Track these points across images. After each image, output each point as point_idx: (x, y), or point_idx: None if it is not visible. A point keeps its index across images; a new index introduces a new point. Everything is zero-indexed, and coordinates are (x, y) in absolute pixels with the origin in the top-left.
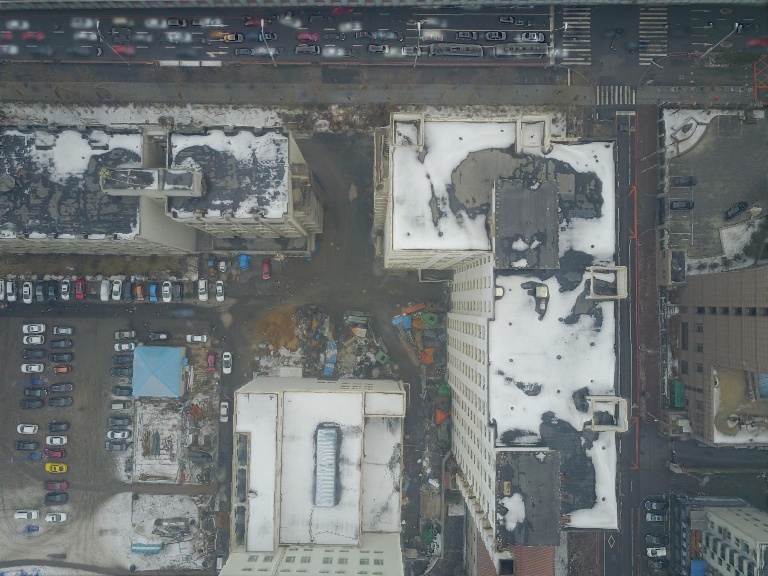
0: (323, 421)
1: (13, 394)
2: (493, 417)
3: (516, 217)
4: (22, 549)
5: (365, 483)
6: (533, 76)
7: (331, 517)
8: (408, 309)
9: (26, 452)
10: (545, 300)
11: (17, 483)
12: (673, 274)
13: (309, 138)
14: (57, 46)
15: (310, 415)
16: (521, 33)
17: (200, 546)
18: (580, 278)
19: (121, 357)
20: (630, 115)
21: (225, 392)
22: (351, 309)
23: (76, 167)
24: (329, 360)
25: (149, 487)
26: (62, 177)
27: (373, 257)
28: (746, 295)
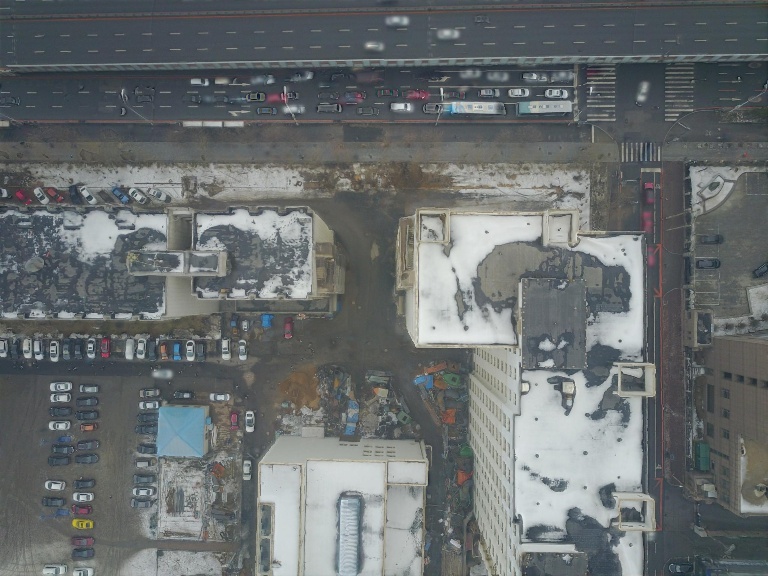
0: (346, 490)
1: (41, 451)
2: (519, 512)
3: (543, 317)
4: None
5: (387, 547)
6: (556, 133)
7: None
8: (430, 369)
9: (54, 508)
10: (572, 396)
11: (45, 538)
12: (699, 336)
13: (331, 197)
14: (82, 106)
15: (333, 484)
16: (544, 90)
17: None
18: (607, 373)
19: (146, 415)
20: (655, 172)
21: (248, 450)
22: (373, 368)
23: (103, 247)
24: (351, 419)
25: (174, 543)
26: (89, 257)
27: (395, 316)
28: None
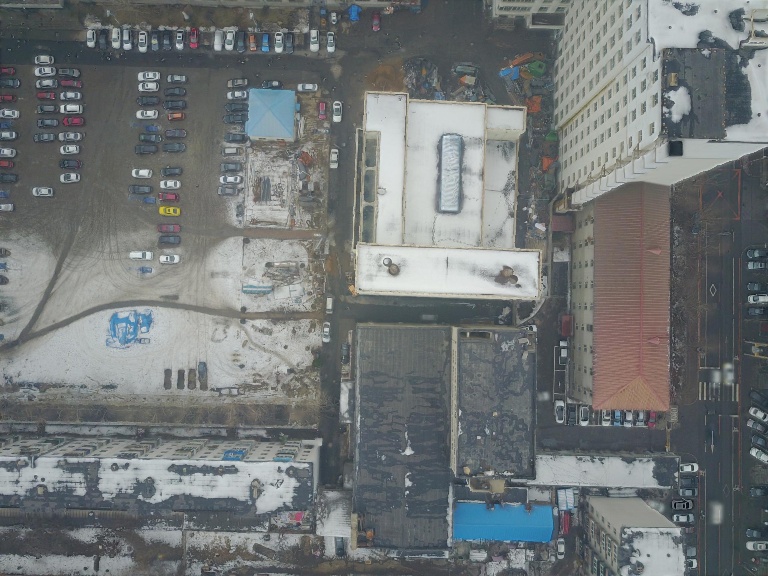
0: (446, 132)
1: (128, 141)
2: (651, 36)
3: None
4: (136, 290)
5: None
6: None
7: (453, 225)
8: (515, 60)
9: (140, 196)
10: None
11: (131, 226)
12: None
13: None
14: None
15: (434, 126)
16: None
17: (309, 289)
18: None
19: (234, 104)
20: None
21: (335, 141)
22: (459, 61)
23: None
24: None
25: (260, 232)
26: None
27: (481, 11)
28: None
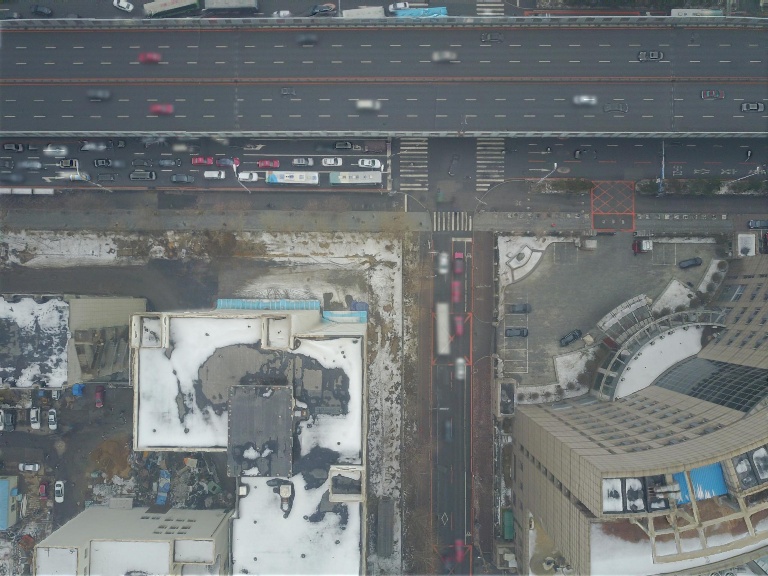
0: (130, 570)
1: None
2: None
3: (248, 425)
4: None
5: None
6: (370, 202)
7: None
8: None
9: None
10: None
11: None
12: (502, 406)
13: (144, 264)
14: None
15: (117, 564)
16: (358, 159)
17: None
18: (326, 475)
19: None
20: (466, 241)
21: (58, 521)
22: None
23: None
24: (161, 489)
25: None
26: None
27: None
28: (542, 453)
